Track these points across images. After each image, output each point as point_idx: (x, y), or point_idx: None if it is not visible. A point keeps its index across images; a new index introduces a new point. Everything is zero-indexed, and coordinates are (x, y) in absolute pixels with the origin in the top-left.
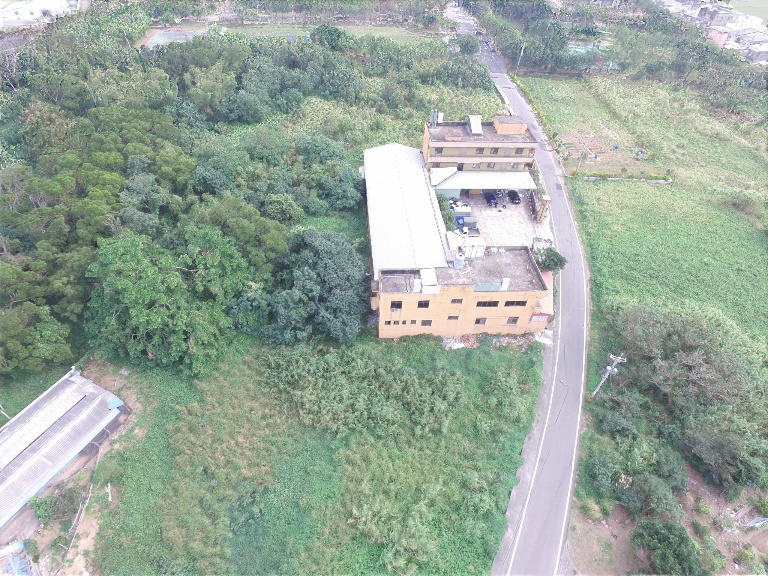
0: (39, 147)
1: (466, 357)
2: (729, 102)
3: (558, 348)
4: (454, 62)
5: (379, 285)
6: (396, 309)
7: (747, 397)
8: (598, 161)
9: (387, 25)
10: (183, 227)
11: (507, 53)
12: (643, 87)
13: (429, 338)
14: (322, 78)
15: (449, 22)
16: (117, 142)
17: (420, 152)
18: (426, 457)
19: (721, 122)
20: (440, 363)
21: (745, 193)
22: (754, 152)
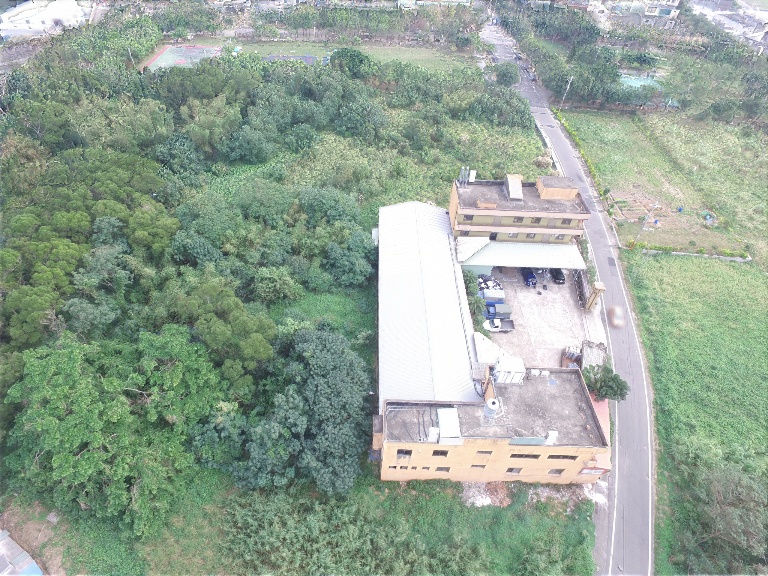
0: (6, 193)
1: (493, 520)
2: None
3: (615, 511)
4: (489, 94)
5: (383, 426)
6: (404, 456)
7: None
8: (658, 227)
9: (417, 46)
10: (153, 309)
11: (551, 86)
12: (707, 129)
13: (445, 486)
14: (339, 110)
15: (485, 44)
16: (87, 198)
17: (446, 213)
18: None
19: None
20: (458, 535)
21: None
22: None
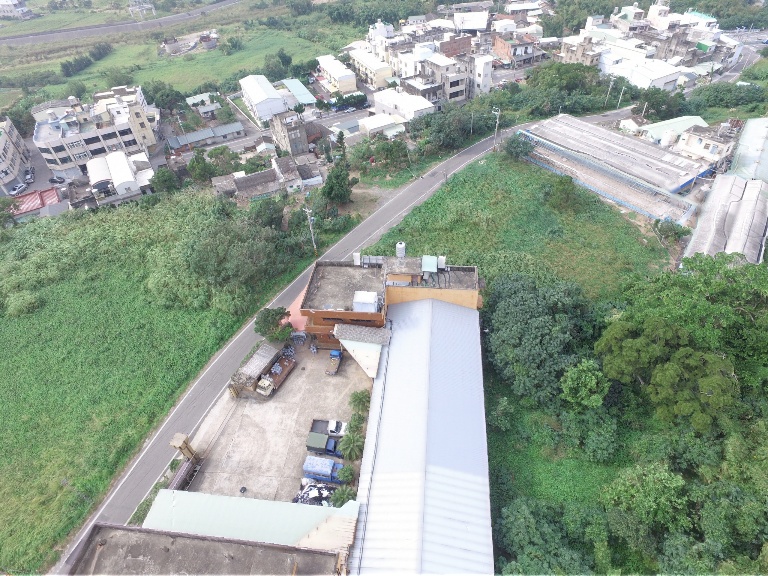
0: None
1: None
2: None
3: None
4: None
5: None
6: None
7: None
8: None
9: None
10: None
11: None
12: None
13: None
14: None
15: None
16: None
17: None
18: None
19: None
20: None
21: None
22: None
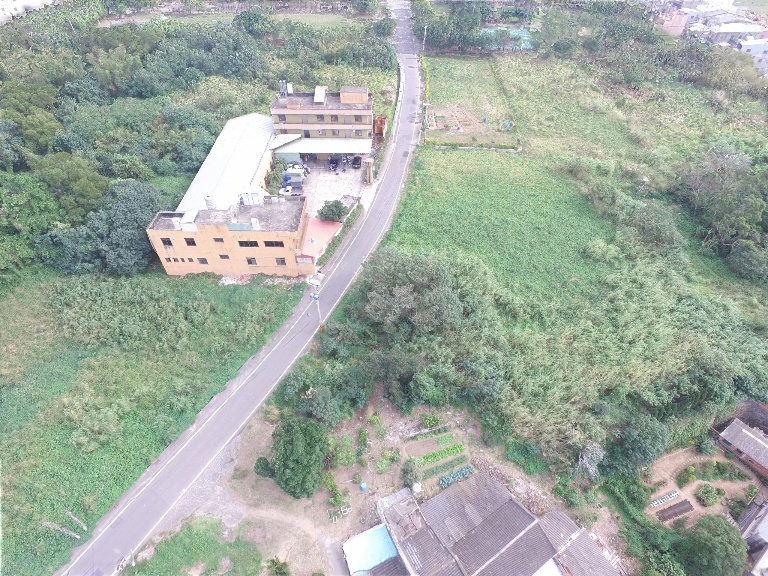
0: None
1: (233, 292)
2: (628, 78)
3: (321, 288)
4: (365, 44)
5: (151, 224)
6: (169, 246)
7: (459, 331)
8: (460, 132)
9: (325, 12)
10: None
11: (416, 34)
12: (551, 66)
13: (209, 276)
14: None
15: (384, 8)
16: None
17: None
18: (157, 368)
19: (615, 98)
20: (199, 294)
21: (581, 160)
22: (623, 124)
